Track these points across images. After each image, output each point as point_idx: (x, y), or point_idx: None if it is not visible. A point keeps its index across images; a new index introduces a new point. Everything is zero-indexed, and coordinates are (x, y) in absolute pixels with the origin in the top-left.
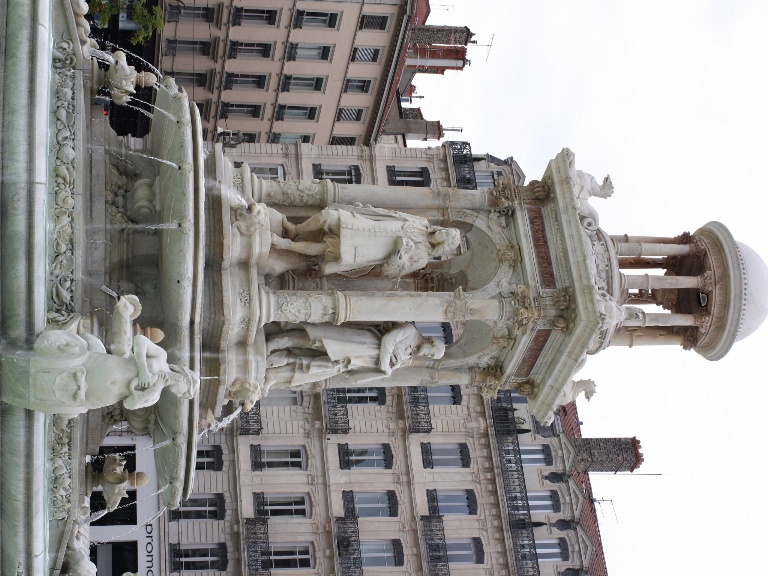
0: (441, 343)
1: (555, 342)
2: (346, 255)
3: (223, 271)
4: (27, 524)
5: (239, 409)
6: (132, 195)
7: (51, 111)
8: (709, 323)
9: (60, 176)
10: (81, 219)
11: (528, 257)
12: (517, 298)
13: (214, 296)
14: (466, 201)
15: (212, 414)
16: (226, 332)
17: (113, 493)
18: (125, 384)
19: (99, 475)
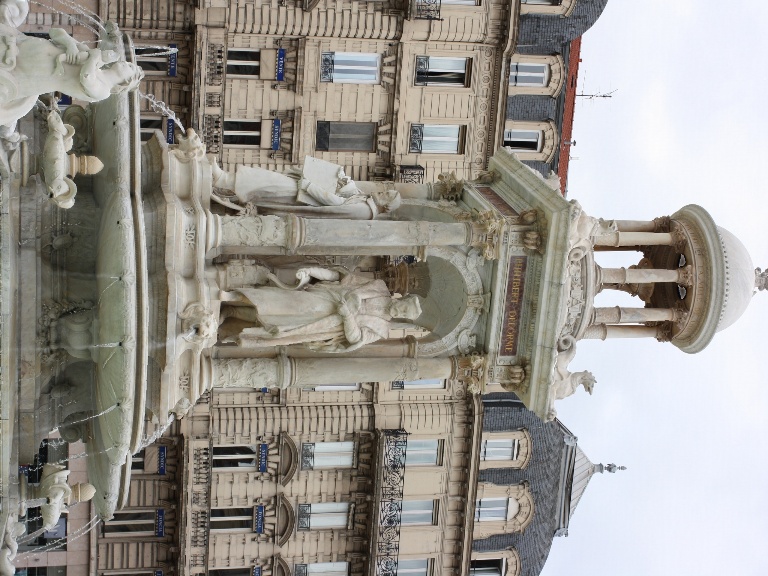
0: None
1: (503, 189)
2: None
3: None
4: None
5: None
6: None
7: None
8: None
9: None
10: None
11: None
12: None
13: None
14: None
15: None
16: None
17: None
18: None
19: None
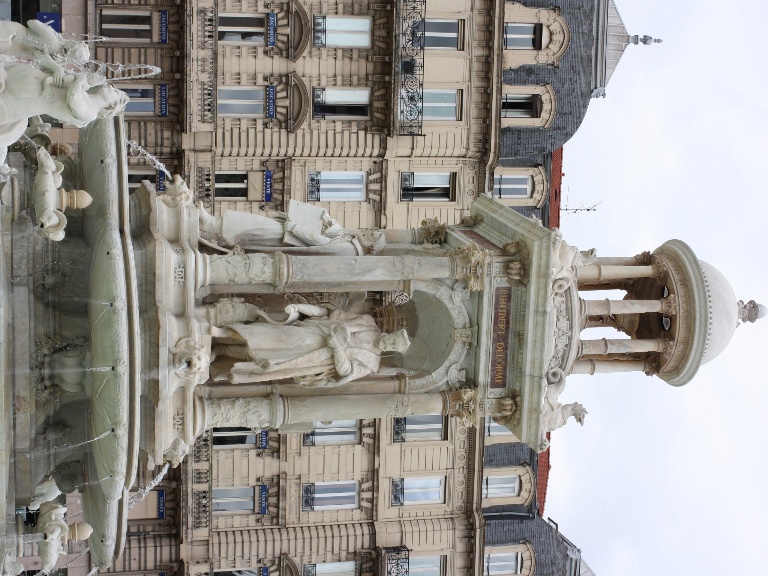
0: None
1: (485, 230)
2: None
3: None
4: None
5: None
6: None
7: None
8: None
9: None
10: None
11: None
12: None
13: None
14: None
15: None
16: None
17: None
18: None
19: None
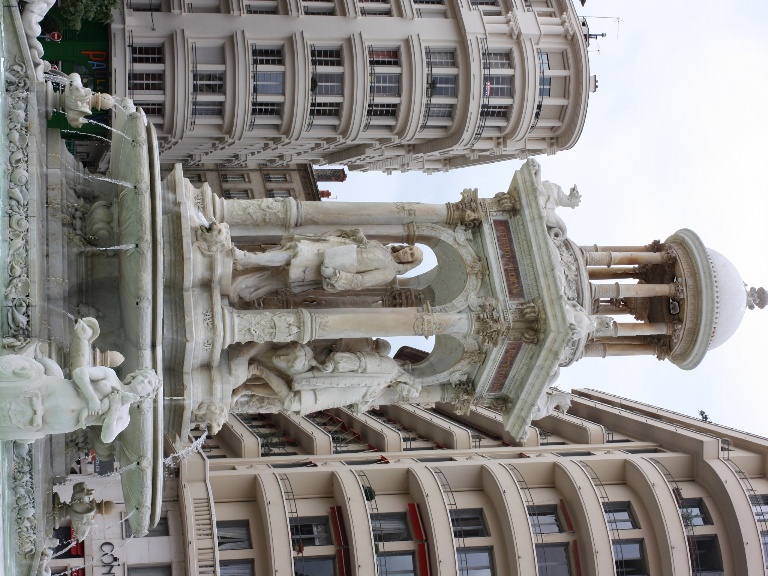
0: None
1: None
2: None
3: None
4: None
5: None
6: (92, 436)
7: (9, 488)
8: None
9: None
10: None
11: (487, 374)
12: None
13: None
14: None
15: None
16: None
17: None
18: None
19: None
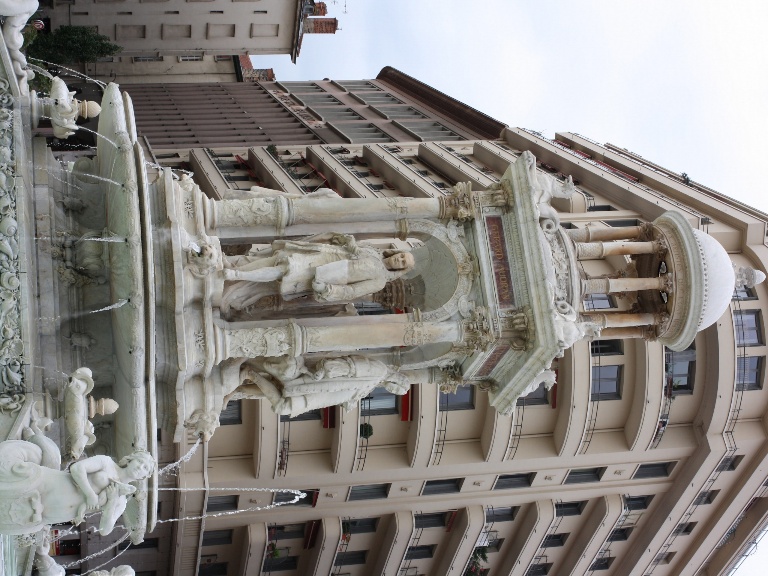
0: None
1: None
2: None
3: None
4: None
5: None
6: None
7: None
8: None
9: None
10: None
11: (475, 365)
12: None
13: None
14: None
15: None
16: None
17: None
18: None
19: None
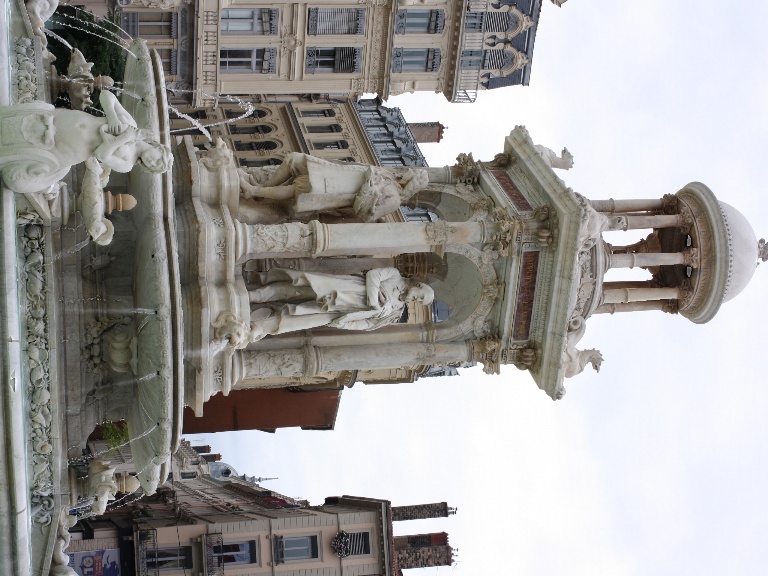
0: (429, 286)
1: (545, 270)
2: (316, 184)
3: (194, 198)
4: (0, 306)
5: (226, 341)
6: None
7: (11, 50)
8: (699, 256)
9: (22, 76)
10: (44, 96)
11: (500, 196)
12: (496, 217)
13: (187, 217)
14: (430, 174)
15: (201, 399)
16: (202, 245)
17: (100, 482)
18: (95, 130)
19: (84, 480)
